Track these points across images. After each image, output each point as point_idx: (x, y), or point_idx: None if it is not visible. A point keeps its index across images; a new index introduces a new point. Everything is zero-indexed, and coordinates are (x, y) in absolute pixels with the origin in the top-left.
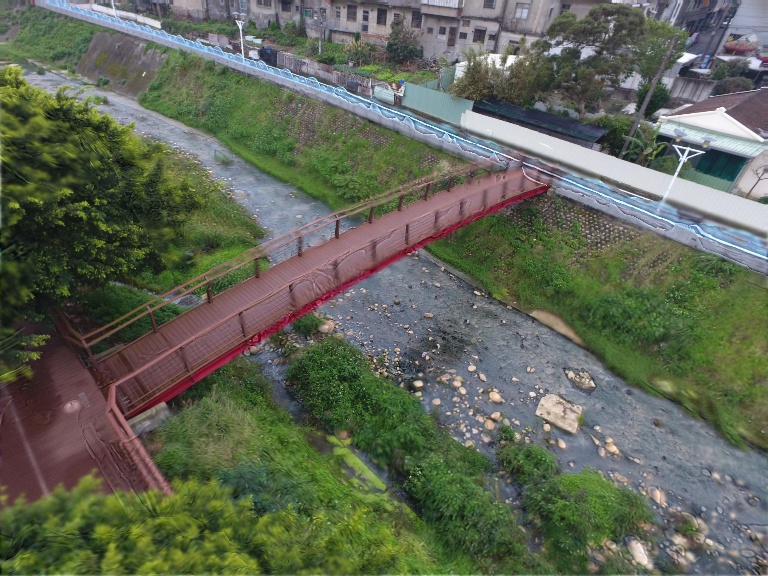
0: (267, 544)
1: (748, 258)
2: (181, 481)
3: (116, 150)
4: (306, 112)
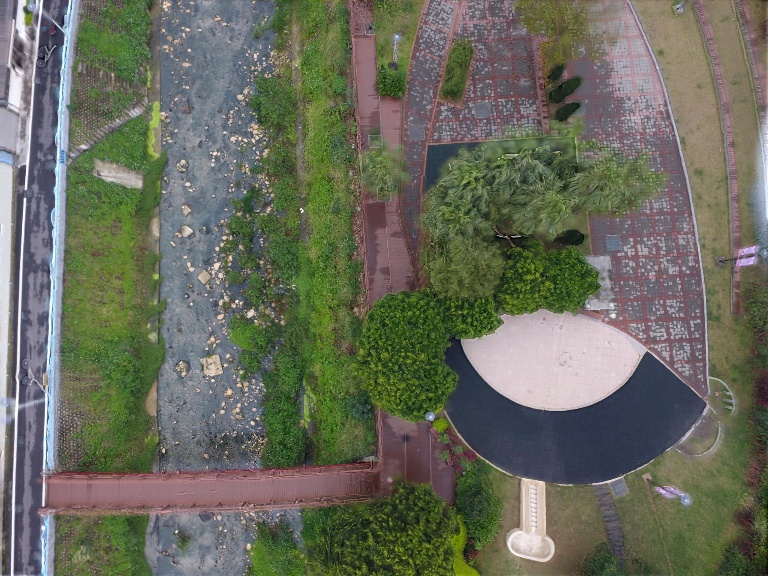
0: (363, 387)
1: (33, 340)
2: (367, 429)
3: None
4: None
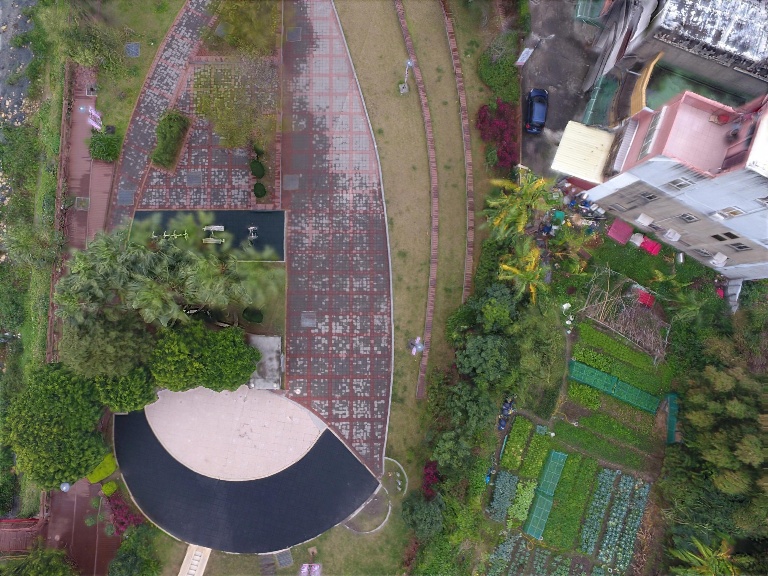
0: None
1: None
2: None
3: None
4: None
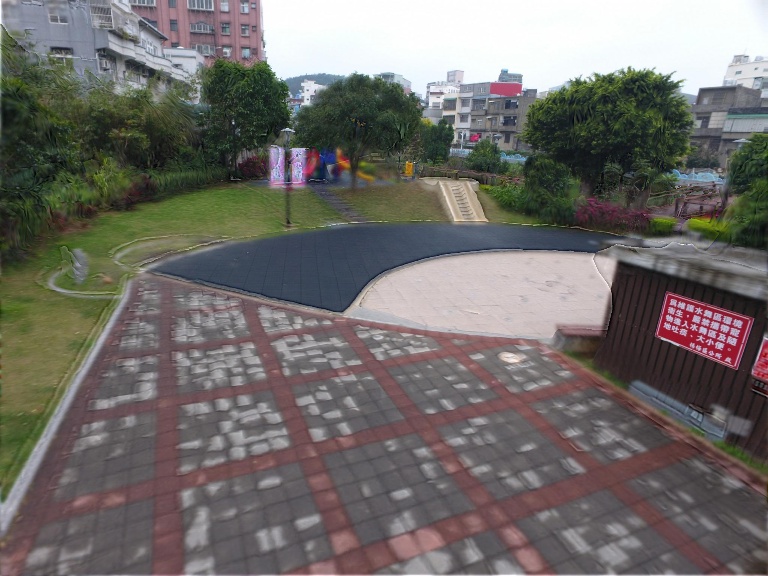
0: None
1: None
2: None
3: None
4: None
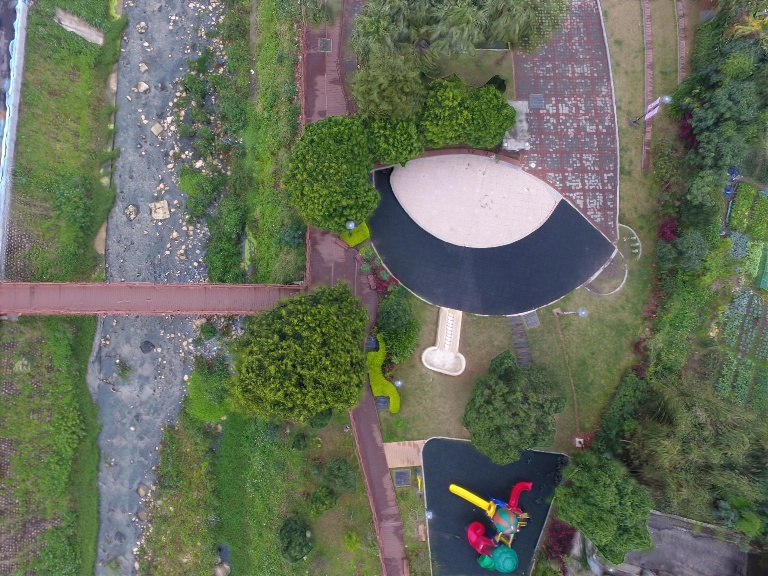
0: None
1: None
2: (297, 253)
3: None
4: (4, 556)
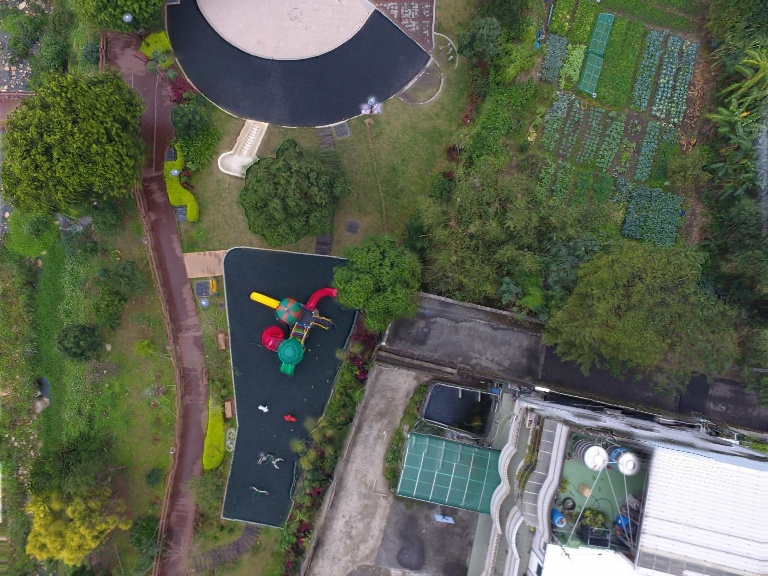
0: None
1: None
2: (97, 68)
3: (0, 449)
4: None
